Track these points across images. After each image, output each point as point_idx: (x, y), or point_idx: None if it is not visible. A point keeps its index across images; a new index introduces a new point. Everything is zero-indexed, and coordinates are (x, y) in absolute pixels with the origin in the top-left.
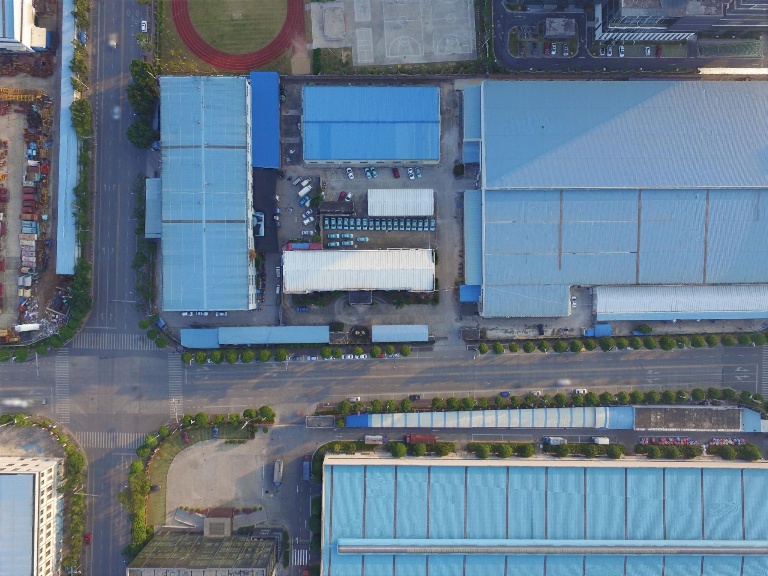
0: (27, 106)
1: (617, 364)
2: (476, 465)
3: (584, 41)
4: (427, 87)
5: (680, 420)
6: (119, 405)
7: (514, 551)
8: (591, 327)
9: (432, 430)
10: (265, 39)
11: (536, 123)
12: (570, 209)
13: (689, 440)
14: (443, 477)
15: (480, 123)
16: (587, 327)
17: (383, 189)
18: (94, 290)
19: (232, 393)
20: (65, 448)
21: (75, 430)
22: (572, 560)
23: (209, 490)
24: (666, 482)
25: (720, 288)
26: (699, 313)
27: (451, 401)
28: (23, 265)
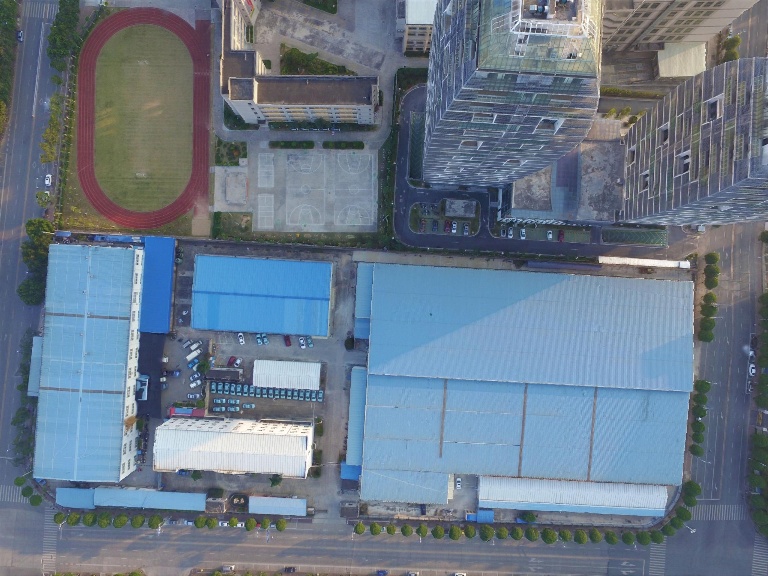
0: None
1: (499, 549)
2: None
3: (486, 221)
4: (320, 263)
5: None
6: None
7: None
8: (475, 510)
9: None
10: (167, 199)
11: (424, 310)
12: (454, 398)
13: None
14: None
15: None
16: (471, 510)
17: (270, 361)
18: None
19: (106, 552)
20: None
21: None
22: None
23: None
24: None
25: (607, 483)
26: (584, 507)
27: None
28: None
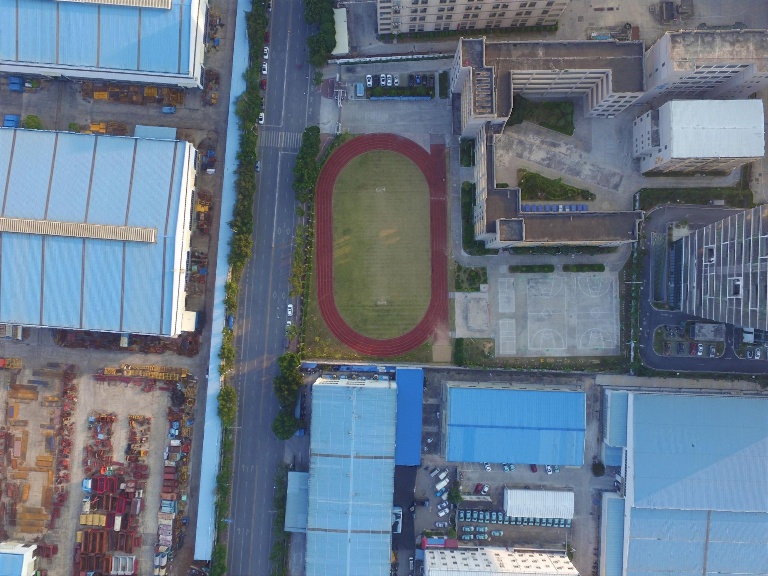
0: (172, 385)
1: None
2: None
3: (731, 342)
4: (573, 393)
5: None
6: None
7: None
8: None
9: None
10: (408, 325)
11: (686, 441)
12: (717, 529)
13: None
14: None
15: (626, 431)
16: None
17: (523, 491)
18: (227, 570)
19: None
20: None
21: None
22: None
23: None
24: None
25: None
26: None
27: None
28: (160, 544)
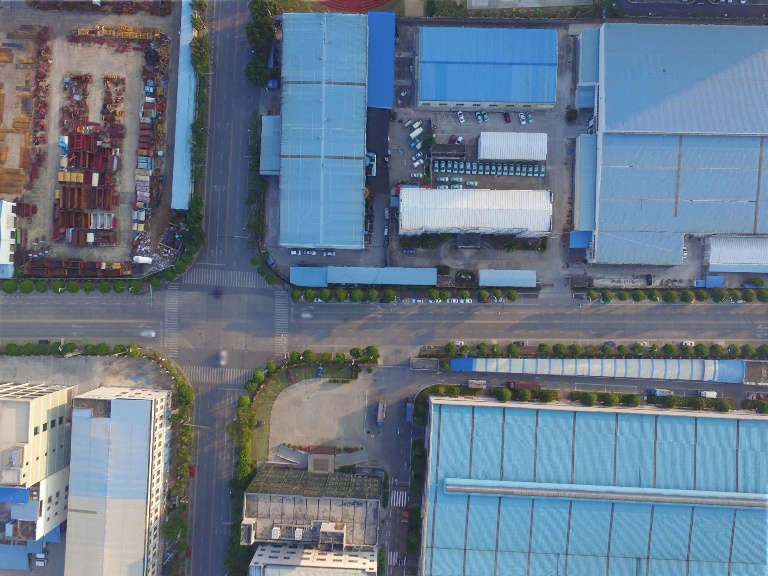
0: (145, 44)
1: (726, 317)
2: (585, 410)
3: None
4: (545, 29)
5: None
6: (226, 341)
7: (622, 498)
8: (701, 279)
9: (535, 377)
10: None
11: (657, 66)
12: (689, 155)
13: None
14: (551, 421)
15: (598, 67)
16: (697, 279)
17: (496, 132)
18: (205, 227)
19: (337, 333)
20: (176, 379)
21: (183, 364)
22: (680, 510)
23: (312, 428)
24: None
25: None
26: None
27: (559, 347)
28: (138, 200)
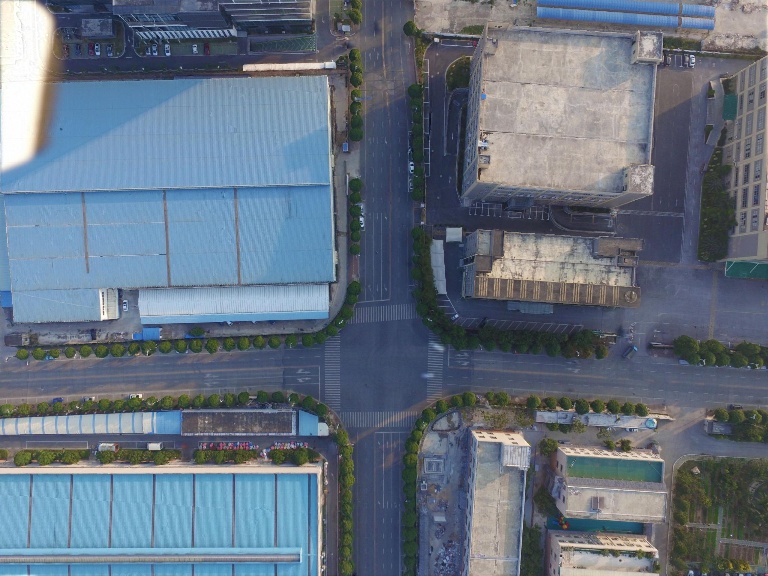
0: None
1: (174, 368)
2: None
3: (131, 41)
4: None
5: (229, 424)
6: None
7: (32, 560)
8: None
9: None
10: None
11: (54, 125)
12: (93, 212)
13: (249, 445)
14: None
15: None
16: (140, 331)
17: None
18: None
19: None
20: None
21: None
22: (97, 569)
23: None
24: (196, 488)
25: (267, 289)
26: (246, 315)
27: None
28: None
